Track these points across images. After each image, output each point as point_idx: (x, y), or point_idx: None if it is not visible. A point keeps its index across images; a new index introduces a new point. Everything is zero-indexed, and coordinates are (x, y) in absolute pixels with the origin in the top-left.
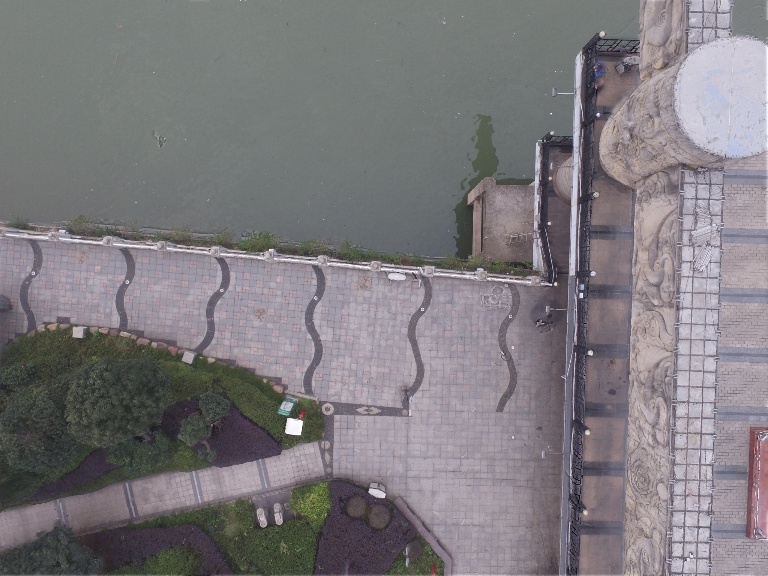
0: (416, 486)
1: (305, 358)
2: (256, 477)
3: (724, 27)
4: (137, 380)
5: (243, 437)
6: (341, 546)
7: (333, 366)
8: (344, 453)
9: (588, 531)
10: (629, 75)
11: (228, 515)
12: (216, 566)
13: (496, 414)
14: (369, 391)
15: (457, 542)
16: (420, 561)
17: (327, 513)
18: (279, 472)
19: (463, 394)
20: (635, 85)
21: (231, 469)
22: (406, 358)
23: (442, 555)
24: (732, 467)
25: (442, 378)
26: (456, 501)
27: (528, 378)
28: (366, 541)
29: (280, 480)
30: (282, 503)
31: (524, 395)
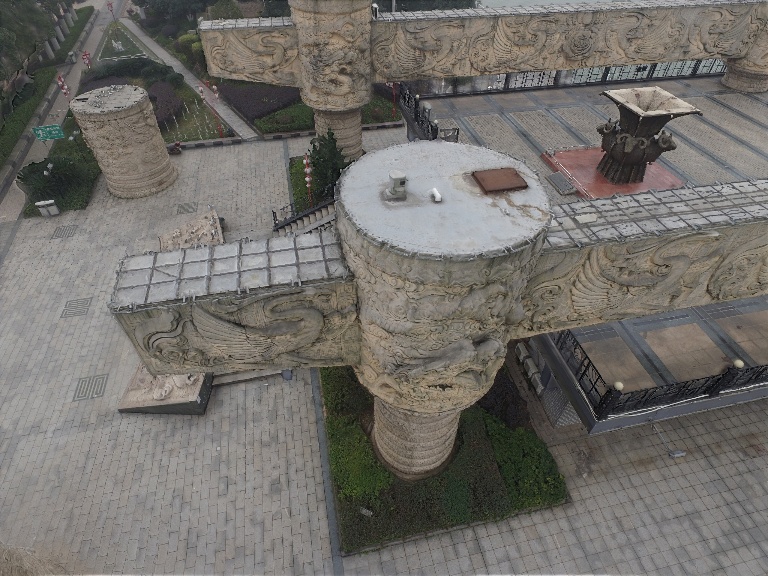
0: None
1: None
2: None
3: None
4: None
5: None
6: None
7: None
8: None
9: (486, 99)
10: None
11: None
12: None
13: None
14: None
15: None
16: (396, 113)
17: None
18: None
19: None
20: None
21: None
22: None
23: None
24: (590, 143)
25: None
26: None
27: None
28: None
29: None
30: None
31: None
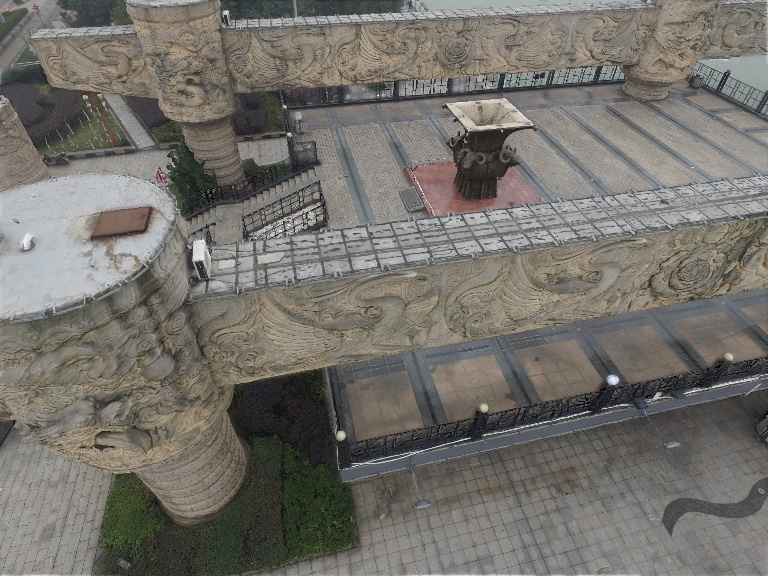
0: None
1: None
2: None
3: (733, 2)
4: (398, 1)
5: None
6: None
7: None
8: None
9: None
10: (693, 89)
11: None
12: None
13: None
14: None
15: None
16: None
17: None
18: None
19: None
20: (690, 91)
21: None
22: None
23: None
24: None
25: None
26: None
27: None
28: None
29: None
30: None
31: None
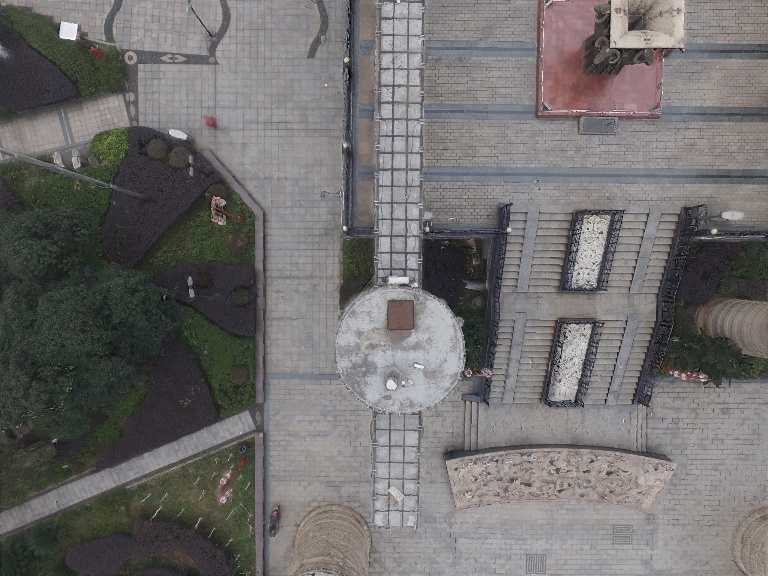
0: (226, 139)
1: (105, 3)
2: (59, 133)
3: None
4: None
5: (31, 68)
6: (137, 182)
7: (134, 12)
8: (150, 105)
9: (369, 115)
10: None
11: (29, 168)
12: (6, 203)
13: (307, 60)
14: (173, 38)
15: (270, 197)
16: (229, 212)
17: (125, 154)
18: (83, 127)
19: (272, 40)
20: None
21: (33, 124)
22: (211, 2)
23: (252, 206)
24: (519, 43)
25: (249, 23)
26: (268, 154)
27: (340, 21)
28: (164, 178)
29: (84, 135)
30: (85, 156)
31: (336, 40)
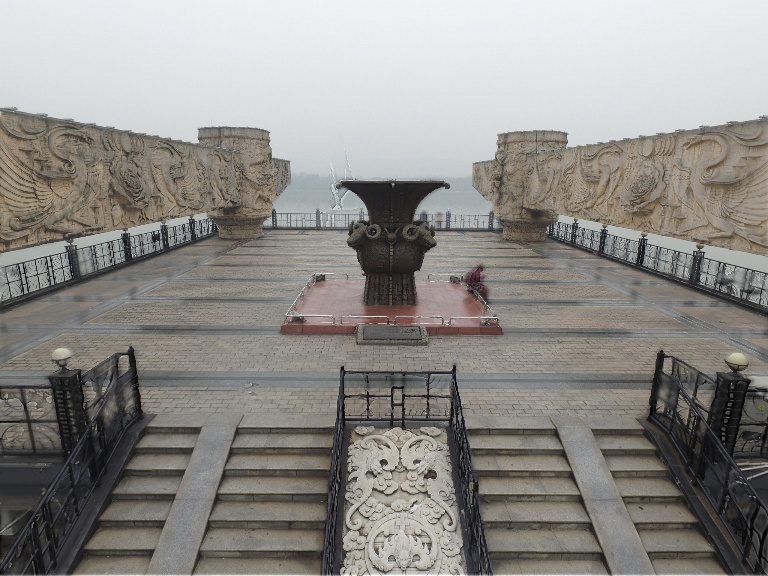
0: None
1: None
2: None
3: None
4: None
5: None
6: None
7: None
8: None
9: None
10: None
11: None
12: None
13: None
14: None
15: None
16: None
17: None
18: None
19: None
20: None
21: None
22: None
23: None
24: (277, 298)
25: None
26: None
27: None
28: None
29: None
30: None
31: None
